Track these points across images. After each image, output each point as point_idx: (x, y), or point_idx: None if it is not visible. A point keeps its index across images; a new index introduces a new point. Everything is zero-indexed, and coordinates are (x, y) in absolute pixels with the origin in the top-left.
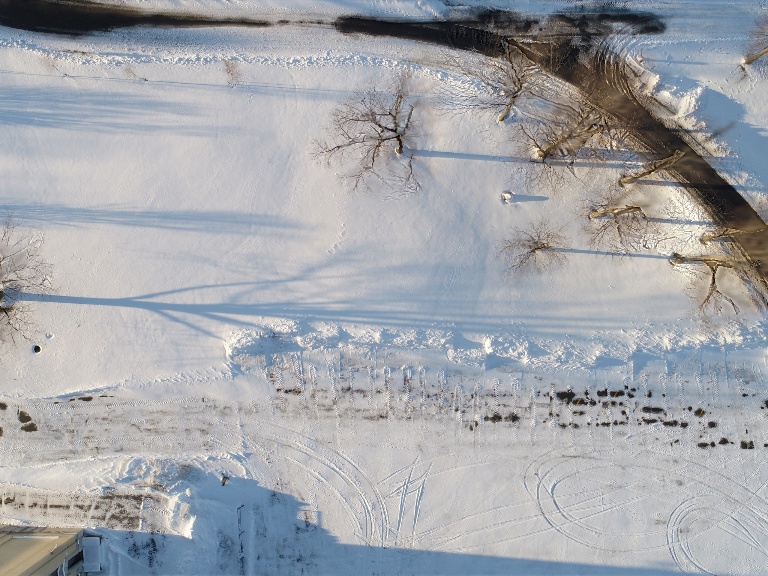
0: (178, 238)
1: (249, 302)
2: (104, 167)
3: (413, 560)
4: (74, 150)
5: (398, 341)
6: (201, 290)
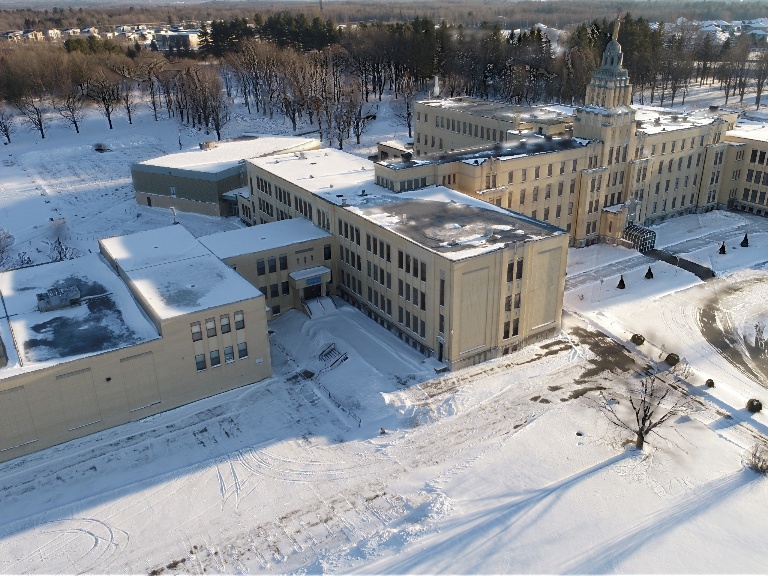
0: (563, 552)
1: (460, 537)
2: (682, 572)
3: (210, 454)
4: (721, 571)
5: (303, 571)
6: (506, 525)
